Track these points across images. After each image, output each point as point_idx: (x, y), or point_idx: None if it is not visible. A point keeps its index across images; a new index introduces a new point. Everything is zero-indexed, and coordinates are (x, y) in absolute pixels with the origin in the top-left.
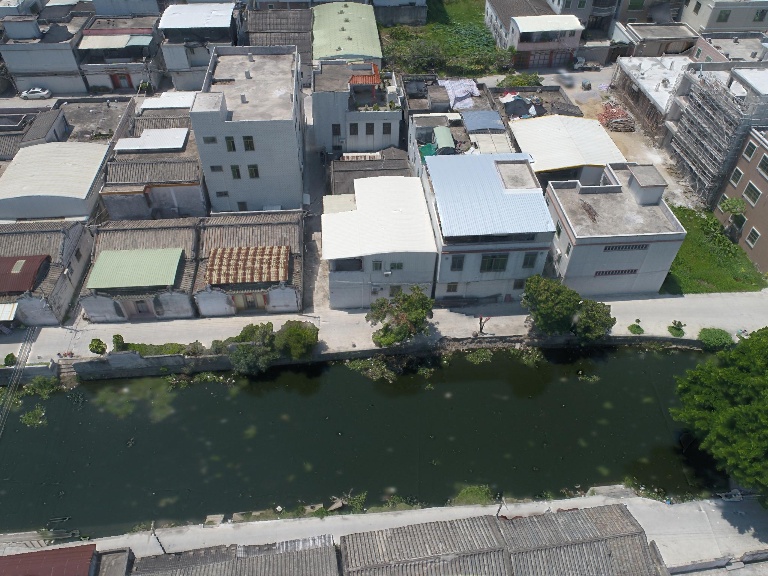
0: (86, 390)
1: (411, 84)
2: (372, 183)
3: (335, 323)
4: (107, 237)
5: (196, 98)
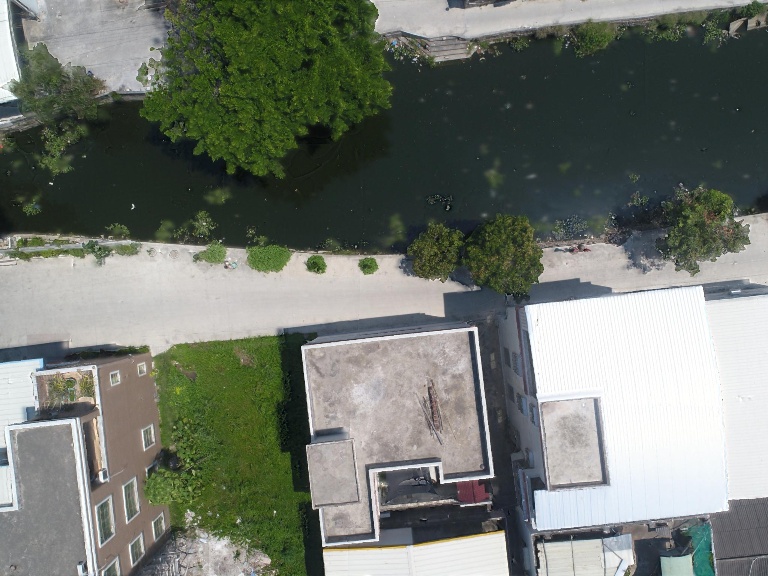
0: None
1: None
2: None
3: (765, 262)
4: None
5: None
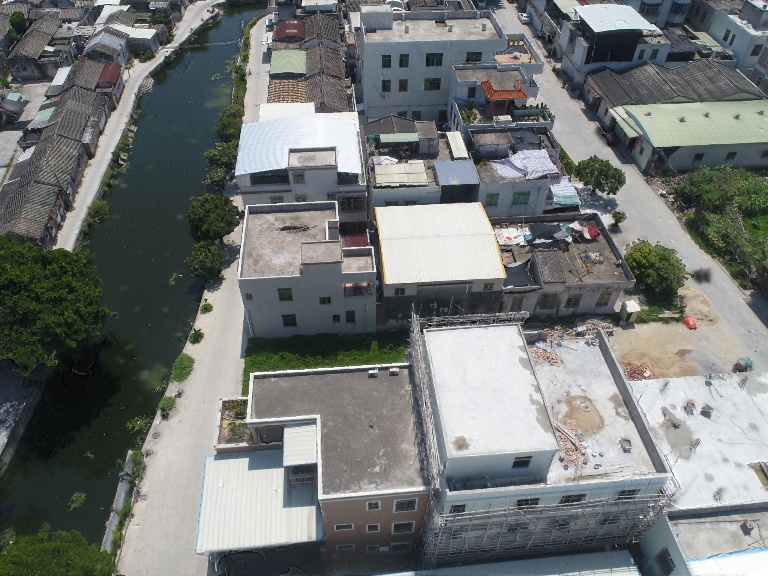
0: (229, 86)
1: (534, 135)
2: (349, 118)
3: None
4: (317, 49)
5: (382, 5)
